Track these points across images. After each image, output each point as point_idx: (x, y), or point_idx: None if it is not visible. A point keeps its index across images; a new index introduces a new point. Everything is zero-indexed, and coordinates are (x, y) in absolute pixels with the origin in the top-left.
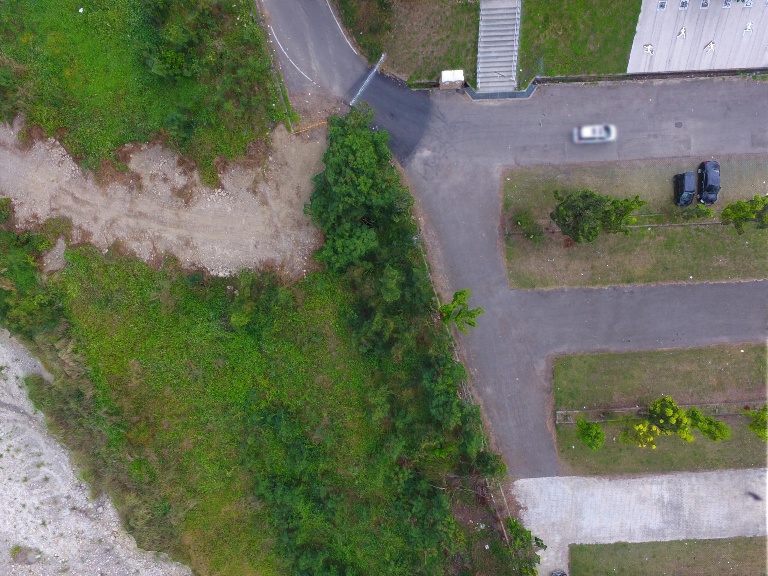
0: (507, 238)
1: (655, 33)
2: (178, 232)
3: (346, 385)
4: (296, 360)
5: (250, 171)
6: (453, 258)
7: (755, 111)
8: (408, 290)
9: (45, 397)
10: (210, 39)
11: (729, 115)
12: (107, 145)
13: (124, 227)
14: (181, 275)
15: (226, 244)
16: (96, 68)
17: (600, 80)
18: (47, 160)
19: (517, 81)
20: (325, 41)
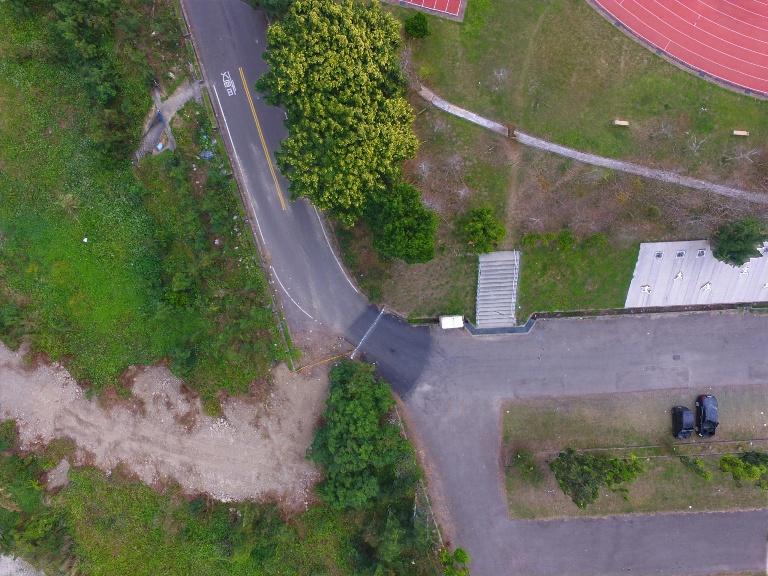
0: (507, 470)
1: (652, 276)
2: (181, 458)
3: None
4: None
5: (252, 406)
6: (453, 490)
7: (752, 344)
8: (409, 540)
9: None
10: (213, 283)
11: (726, 348)
12: (111, 370)
13: (127, 450)
14: (184, 502)
15: (228, 474)
16: (100, 296)
17: (598, 312)
18: (51, 381)
19: (516, 317)
20: (326, 280)
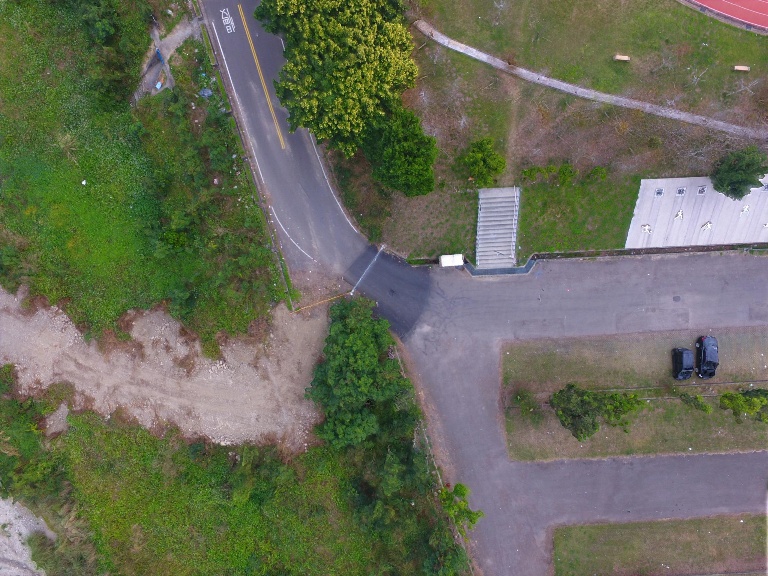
0: (507, 411)
1: (653, 215)
2: (180, 401)
3: (347, 558)
4: (297, 530)
5: (251, 347)
6: (453, 431)
7: (752, 285)
8: (409, 477)
9: (48, 559)
10: (212, 222)
11: (727, 289)
12: (110, 314)
13: (126, 394)
14: (183, 445)
15: (228, 416)
16: (99, 239)
17: (598, 254)
18: (50, 326)
19: (516, 258)
20: (325, 220)
